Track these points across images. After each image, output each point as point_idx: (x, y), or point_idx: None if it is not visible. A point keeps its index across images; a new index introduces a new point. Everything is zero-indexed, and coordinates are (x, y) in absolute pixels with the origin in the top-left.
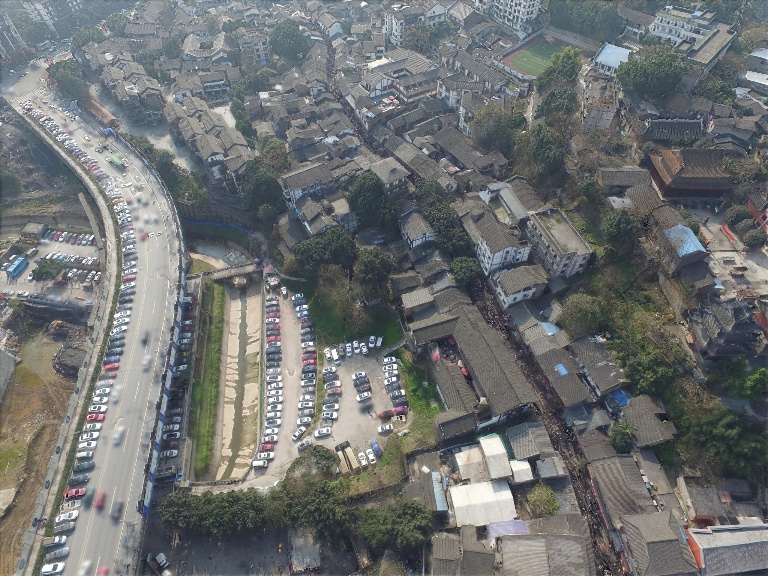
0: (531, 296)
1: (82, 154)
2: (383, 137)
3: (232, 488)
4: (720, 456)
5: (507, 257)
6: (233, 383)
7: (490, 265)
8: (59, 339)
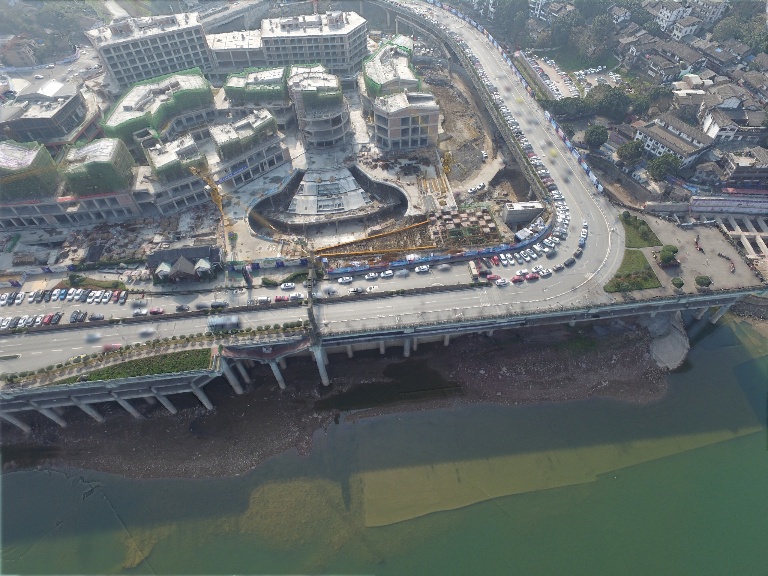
0: (693, 32)
1: None
2: None
3: None
4: None
5: (678, 16)
6: None
7: (668, 22)
8: (420, 75)
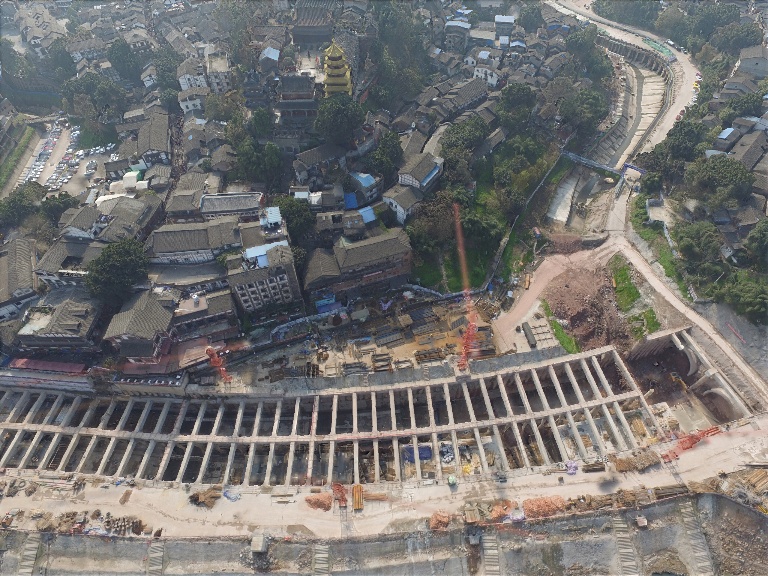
0: (201, 107)
1: None
2: (164, 29)
3: None
4: (242, 163)
5: (192, 85)
6: (23, 180)
7: None
8: None
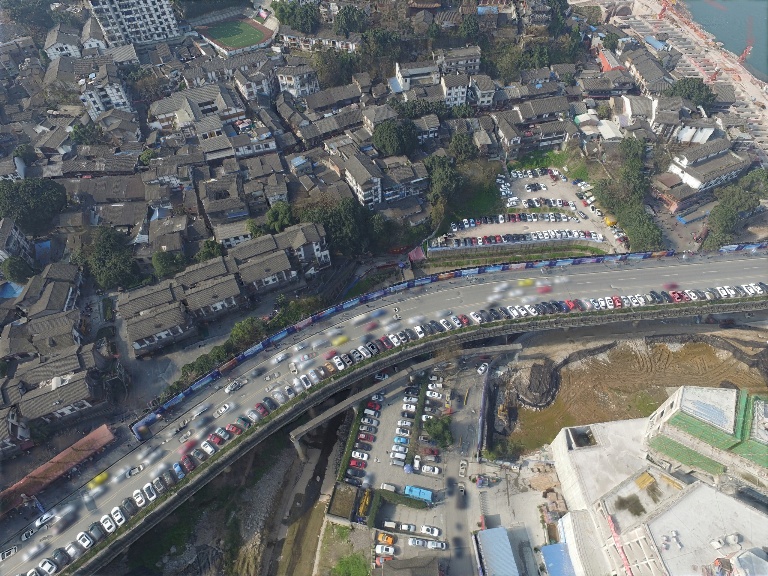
0: None
1: (191, 458)
2: None
3: (618, 251)
4: None
5: None
6: None
7: None
8: (514, 414)
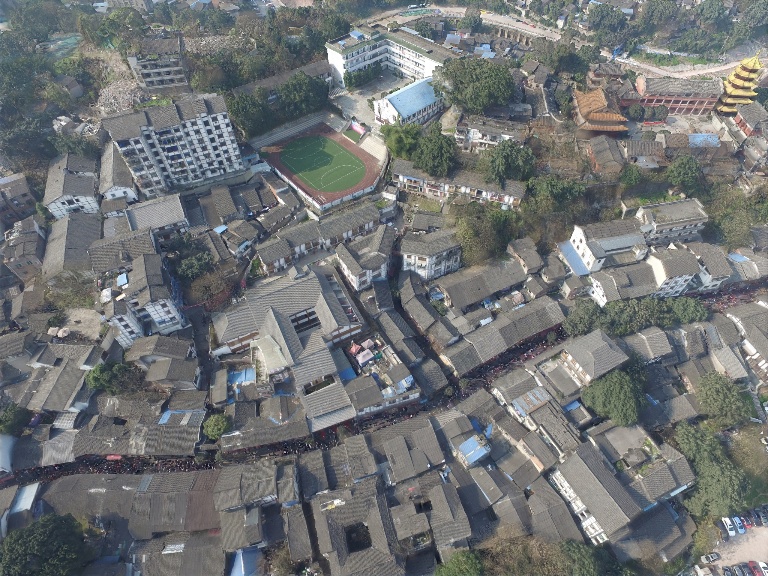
0: None
1: None
2: None
3: None
4: None
5: None
6: None
7: None
8: None
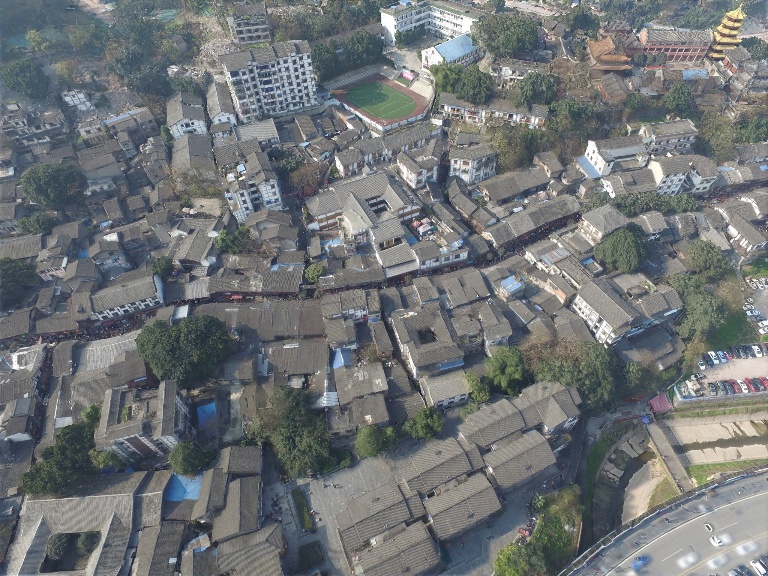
0: None
1: None
2: None
3: None
4: None
5: None
6: None
7: None
8: None
